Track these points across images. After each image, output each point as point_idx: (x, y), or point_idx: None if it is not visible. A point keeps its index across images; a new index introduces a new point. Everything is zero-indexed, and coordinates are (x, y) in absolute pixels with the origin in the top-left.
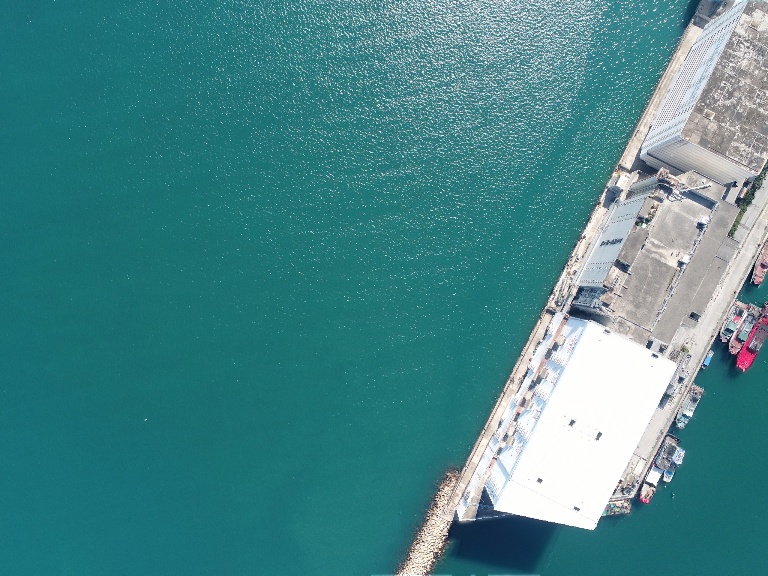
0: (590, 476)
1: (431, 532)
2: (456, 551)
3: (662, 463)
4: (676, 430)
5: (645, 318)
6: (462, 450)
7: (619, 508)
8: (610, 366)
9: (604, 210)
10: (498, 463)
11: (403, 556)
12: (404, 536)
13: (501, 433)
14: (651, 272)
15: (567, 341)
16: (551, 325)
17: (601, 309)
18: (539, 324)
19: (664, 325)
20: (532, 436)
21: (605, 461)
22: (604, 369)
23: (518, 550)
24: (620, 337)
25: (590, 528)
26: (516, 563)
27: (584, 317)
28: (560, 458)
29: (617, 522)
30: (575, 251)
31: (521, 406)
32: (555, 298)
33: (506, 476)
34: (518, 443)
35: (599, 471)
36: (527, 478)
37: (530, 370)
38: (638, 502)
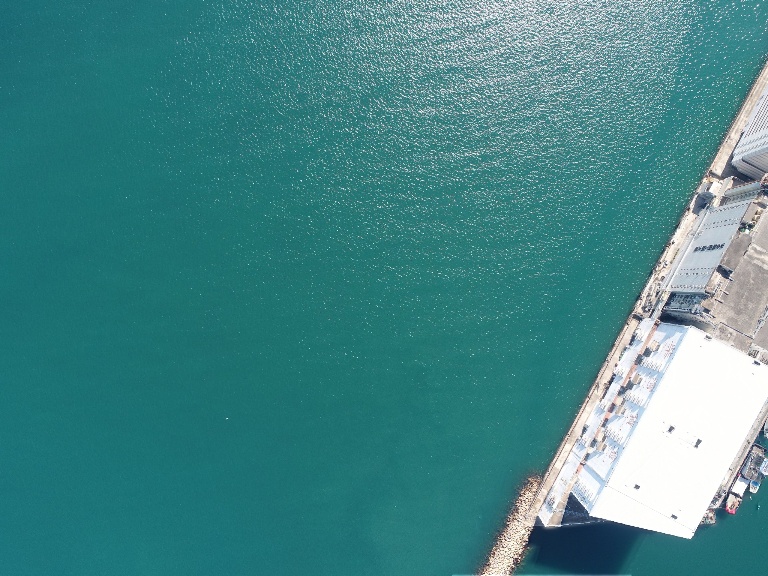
0: (689, 484)
1: (512, 537)
2: (536, 557)
3: (749, 473)
4: (762, 440)
5: (746, 325)
6: (545, 455)
7: (704, 518)
8: (711, 372)
9: (693, 216)
10: (586, 469)
11: (482, 561)
12: (483, 541)
13: (588, 439)
14: (753, 278)
15: (662, 347)
16: (639, 331)
17: (701, 315)
18: (625, 330)
19: (766, 332)
20: (630, 442)
21: (704, 469)
22: (705, 375)
23: (599, 558)
24: (721, 343)
25: (687, 537)
26: (597, 571)
27: (675, 323)
28: (658, 465)
29: (700, 532)
30: (663, 257)
31: (609, 412)
32: (642, 304)
33: (600, 482)
34: (611, 449)
35: (698, 479)
36: (624, 484)
37: (618, 376)
38: (722, 513)
